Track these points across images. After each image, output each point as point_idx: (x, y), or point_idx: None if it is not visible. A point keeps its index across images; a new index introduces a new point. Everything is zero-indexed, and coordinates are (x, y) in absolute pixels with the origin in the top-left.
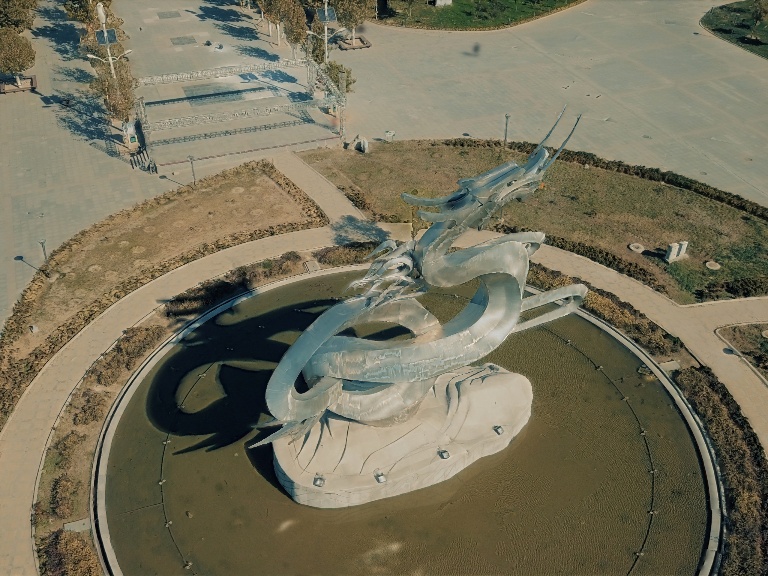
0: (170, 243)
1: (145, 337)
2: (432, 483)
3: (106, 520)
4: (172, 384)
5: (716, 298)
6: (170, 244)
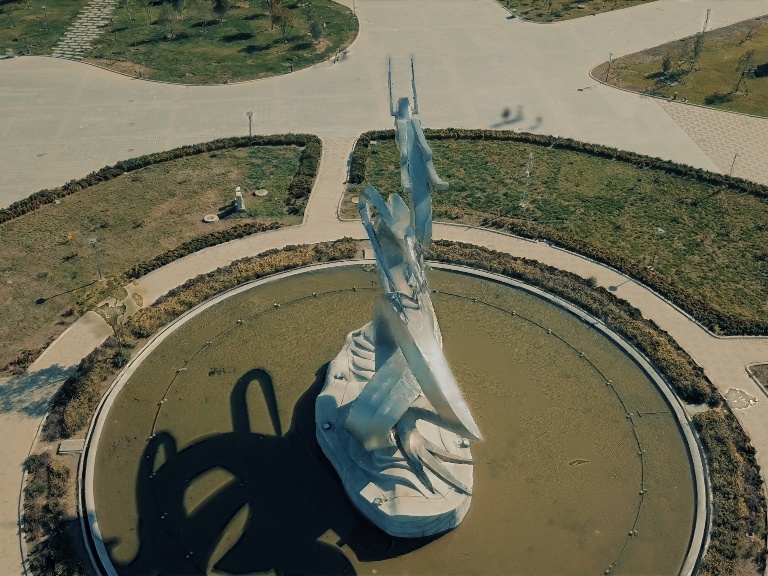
0: None
1: None
2: None
3: None
4: None
5: (304, 205)
6: None
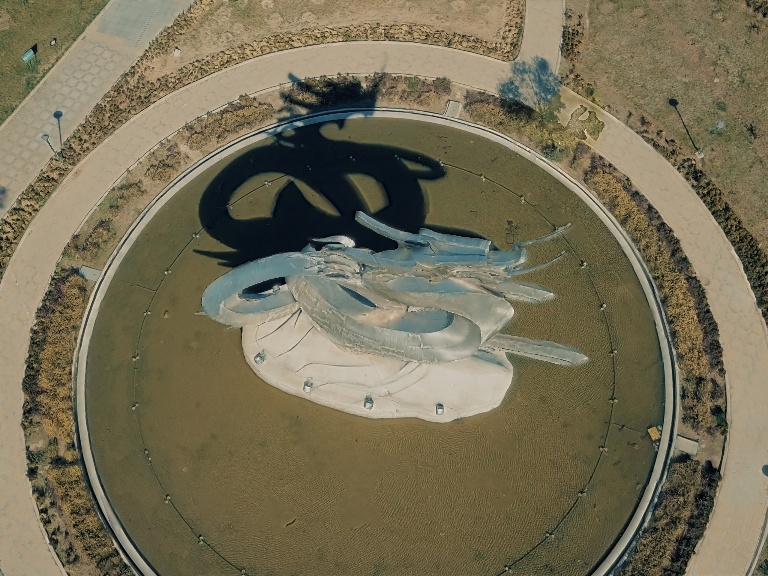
0: (350, 5)
1: (251, 114)
2: (355, 413)
3: (110, 281)
4: (240, 177)
5: None
6: (349, 6)
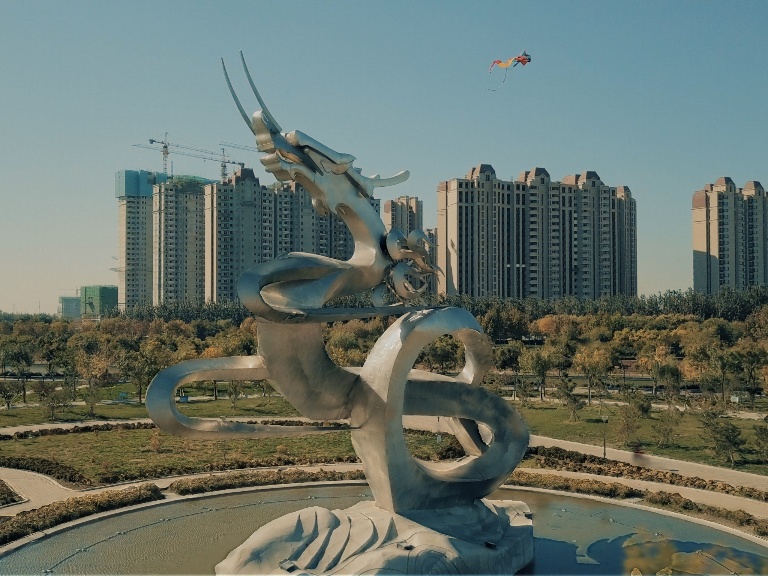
0: None
1: None
2: None
3: None
4: None
5: None
6: None
